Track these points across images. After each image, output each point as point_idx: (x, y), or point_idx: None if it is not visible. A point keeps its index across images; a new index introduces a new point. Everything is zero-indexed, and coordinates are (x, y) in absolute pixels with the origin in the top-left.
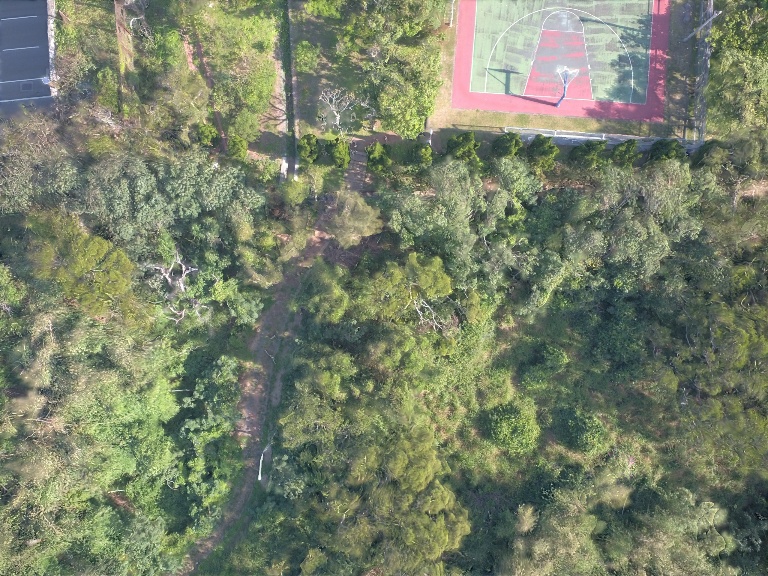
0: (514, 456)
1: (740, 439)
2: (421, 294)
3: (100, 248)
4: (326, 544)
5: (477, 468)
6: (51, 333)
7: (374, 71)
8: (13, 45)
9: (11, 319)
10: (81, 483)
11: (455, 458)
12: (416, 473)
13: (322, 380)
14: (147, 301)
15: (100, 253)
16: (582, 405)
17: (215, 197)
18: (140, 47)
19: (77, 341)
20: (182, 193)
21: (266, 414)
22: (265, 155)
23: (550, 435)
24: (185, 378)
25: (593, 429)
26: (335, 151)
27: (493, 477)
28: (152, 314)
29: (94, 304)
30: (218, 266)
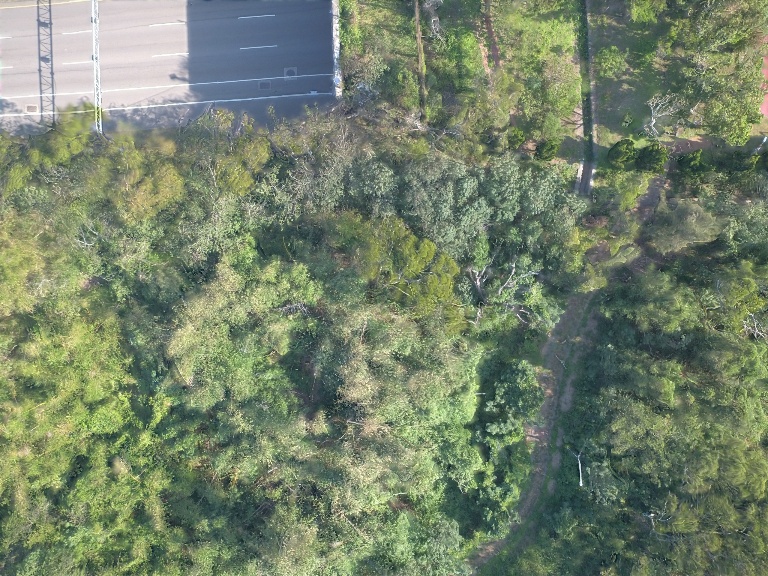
0: None
1: None
2: None
3: (429, 250)
4: (620, 550)
5: None
6: (362, 334)
7: (697, 77)
8: (251, 44)
9: (309, 319)
10: (377, 485)
11: None
12: (758, 482)
13: (661, 387)
14: (452, 304)
15: (429, 255)
16: None
17: (541, 201)
18: (429, 49)
19: (386, 343)
20: (510, 196)
21: (555, 419)
22: (563, 159)
23: None
24: (476, 381)
25: None
26: (661, 157)
27: None
28: (452, 317)
29: (382, 306)
30: (531, 270)
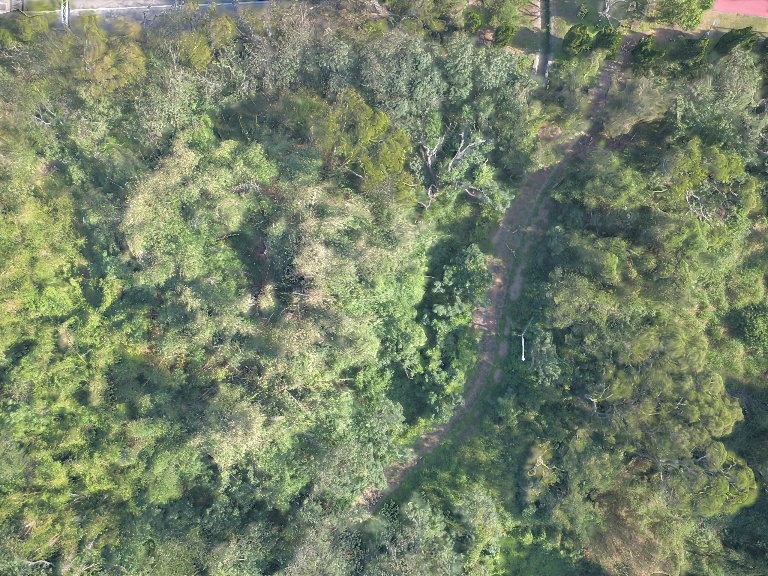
0: (763, 356)
1: None
2: (693, 183)
3: (379, 119)
4: (563, 439)
5: (725, 367)
6: (311, 207)
7: None
8: None
9: (260, 196)
10: (322, 364)
11: None
12: (696, 354)
13: (603, 258)
14: (403, 183)
15: (379, 124)
16: None
17: (493, 76)
18: None
19: (335, 217)
20: (462, 70)
21: (504, 308)
22: (519, 49)
23: None
24: None
25: None
26: (612, 39)
27: (740, 377)
28: (403, 198)
29: (335, 190)
30: (482, 149)
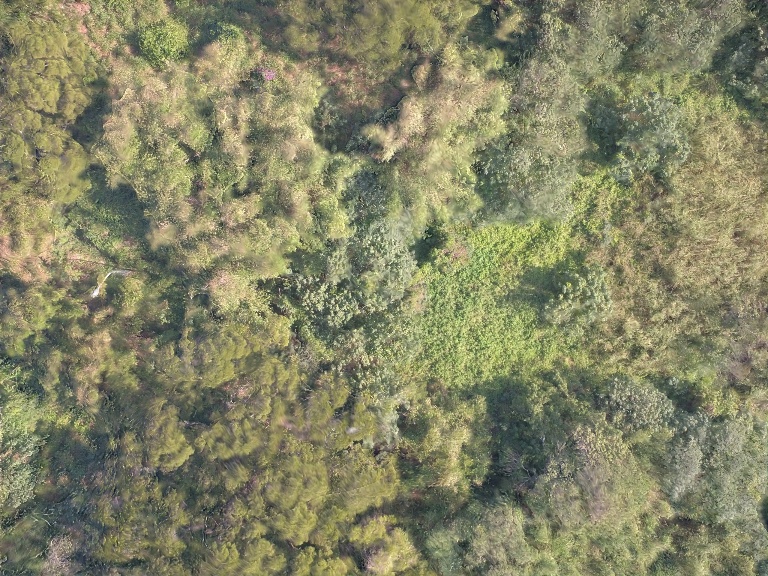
0: (165, 72)
1: (333, 6)
2: None
3: None
4: None
5: (130, 83)
6: None
7: None
8: None
9: None
10: None
11: (110, 75)
12: (32, 39)
13: None
14: None
15: None
16: (228, 21)
17: None
18: None
19: None
20: None
21: None
22: None
23: (200, 53)
24: None
25: (227, 32)
26: None
27: None
28: None
29: None
30: None
